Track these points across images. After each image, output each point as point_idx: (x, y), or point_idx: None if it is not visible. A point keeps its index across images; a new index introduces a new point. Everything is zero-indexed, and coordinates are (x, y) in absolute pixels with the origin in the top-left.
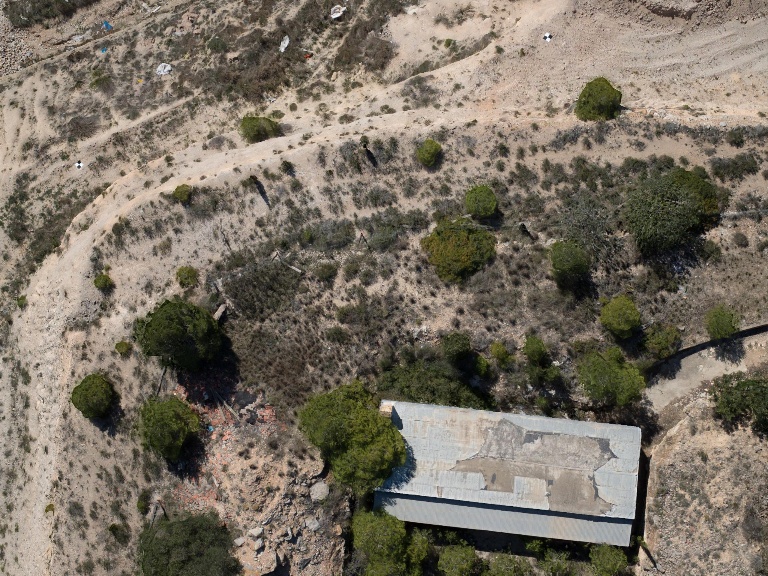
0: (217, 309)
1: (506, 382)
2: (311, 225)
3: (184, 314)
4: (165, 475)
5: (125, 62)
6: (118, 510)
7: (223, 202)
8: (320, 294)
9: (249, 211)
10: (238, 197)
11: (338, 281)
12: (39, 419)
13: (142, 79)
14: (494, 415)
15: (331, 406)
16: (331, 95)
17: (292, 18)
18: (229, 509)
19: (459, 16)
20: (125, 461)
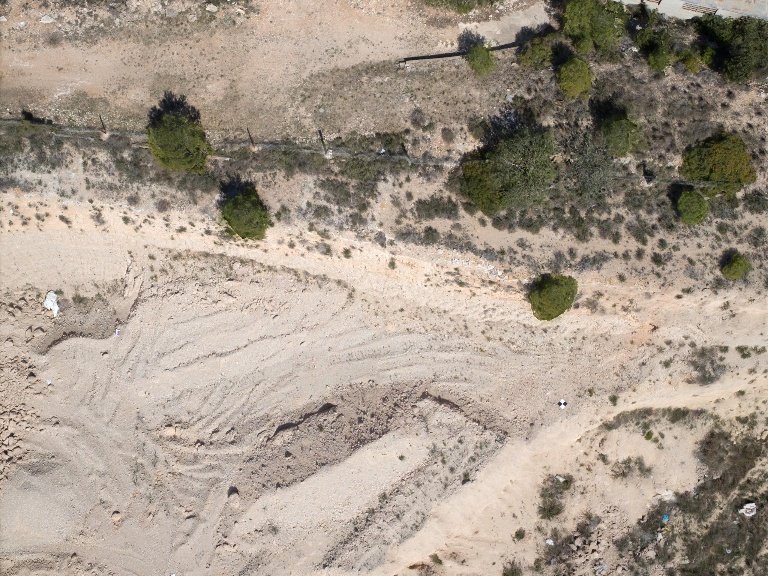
0: None
1: None
2: None
3: None
4: None
5: None
6: None
7: None
8: None
9: None
10: None
11: None
12: None
13: None
14: (708, 3)
15: None
16: None
17: None
18: None
19: (627, 470)
20: None
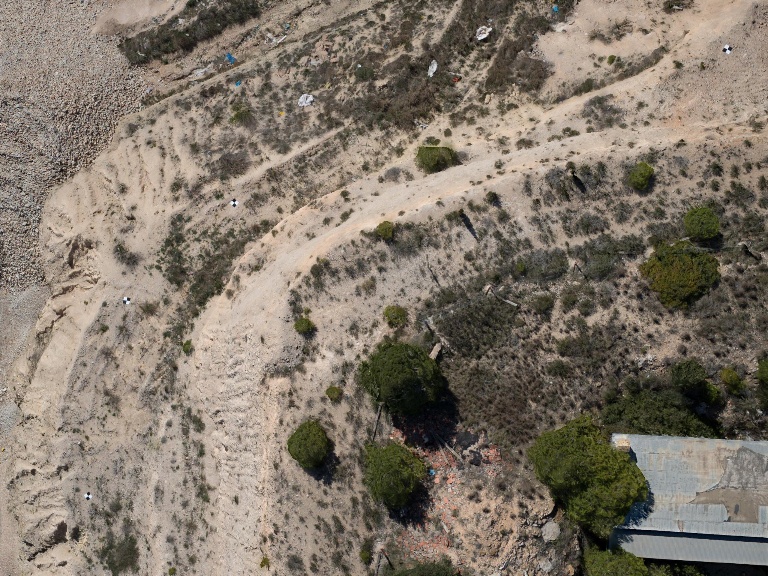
0: (432, 348)
1: (734, 408)
2: (522, 256)
3: (411, 357)
4: (387, 523)
5: (262, 95)
6: (340, 561)
7: (428, 237)
8: (538, 327)
9: (456, 245)
10: (444, 231)
11: (555, 313)
12: (218, 467)
13: (283, 111)
14: (732, 443)
15: (565, 443)
16: (486, 118)
17: (437, 42)
18: (463, 555)
19: (616, 31)
20: (344, 510)
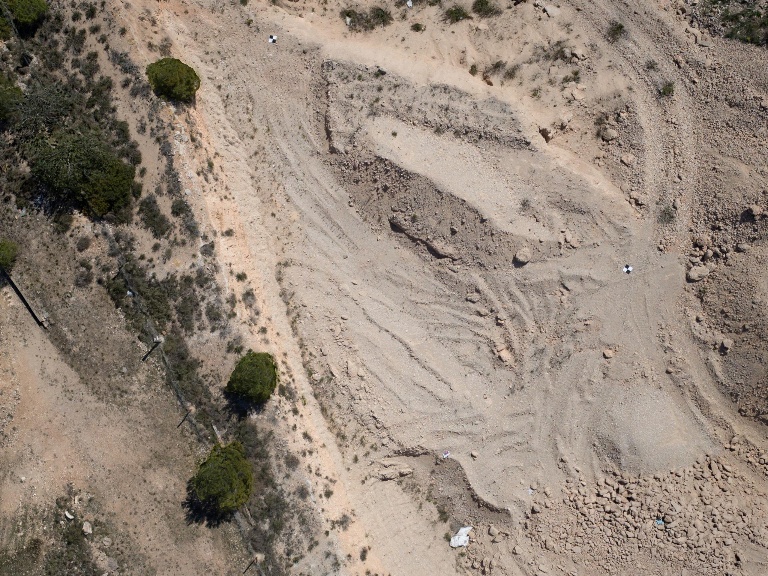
0: None
1: None
2: None
3: None
4: None
5: None
6: None
7: None
8: None
9: None
10: None
11: None
12: None
13: None
14: None
15: None
16: None
17: None
18: None
19: None
20: None
